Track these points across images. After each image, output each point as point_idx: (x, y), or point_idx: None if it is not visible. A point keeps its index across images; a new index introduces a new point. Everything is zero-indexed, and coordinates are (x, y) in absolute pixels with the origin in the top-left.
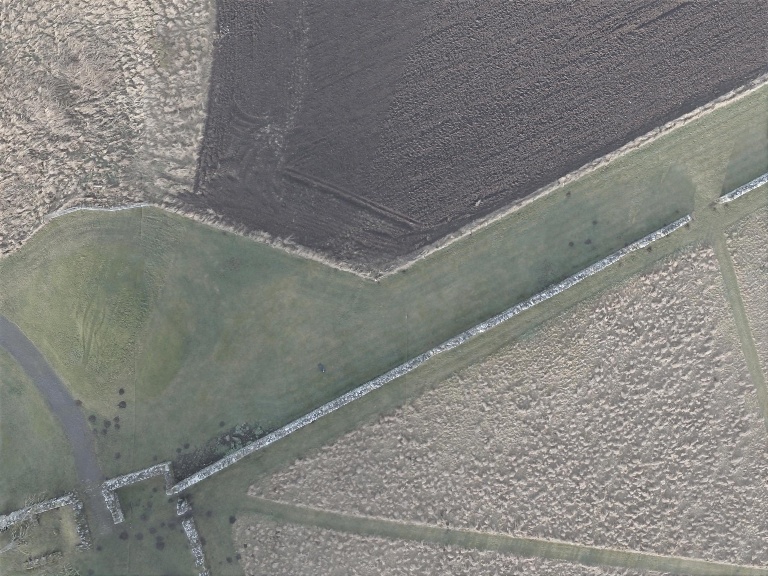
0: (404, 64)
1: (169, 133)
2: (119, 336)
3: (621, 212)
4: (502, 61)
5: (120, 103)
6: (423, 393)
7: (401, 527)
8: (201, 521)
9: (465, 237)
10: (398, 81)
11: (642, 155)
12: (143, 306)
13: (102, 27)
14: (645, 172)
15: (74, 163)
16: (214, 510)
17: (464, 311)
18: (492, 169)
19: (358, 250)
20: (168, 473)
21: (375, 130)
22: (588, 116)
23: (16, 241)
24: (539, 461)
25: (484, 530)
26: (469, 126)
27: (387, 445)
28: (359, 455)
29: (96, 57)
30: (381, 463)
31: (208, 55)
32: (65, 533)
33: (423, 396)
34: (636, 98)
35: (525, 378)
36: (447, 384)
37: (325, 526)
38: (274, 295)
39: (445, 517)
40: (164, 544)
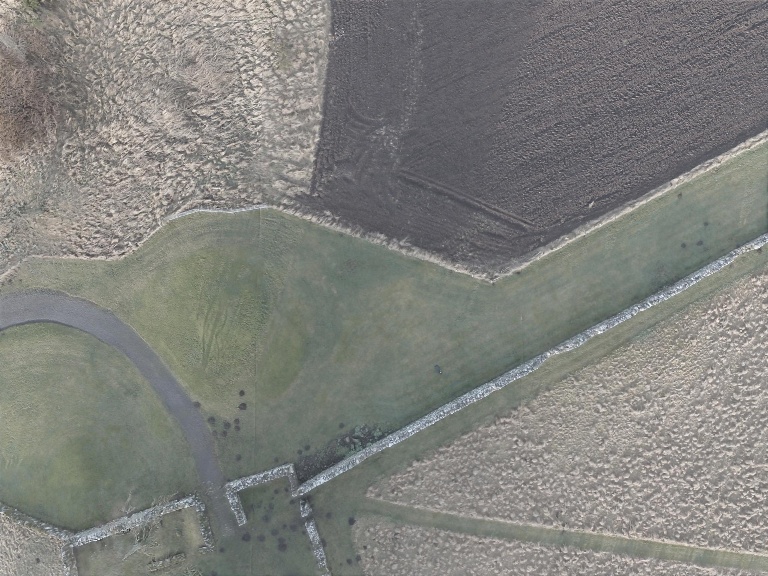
0: (517, 66)
1: (287, 135)
2: (241, 338)
3: (732, 213)
4: (614, 63)
5: (238, 105)
6: (538, 394)
7: (517, 528)
8: (321, 523)
9: (579, 238)
10: (511, 83)
11: (752, 156)
12: (264, 308)
13: (220, 29)
14: (755, 173)
15: (193, 165)
16: (333, 512)
17: (579, 312)
18: (605, 170)
19: (473, 252)
20: (292, 475)
21: (489, 132)
22: (700, 117)
23: (133, 243)
24: (653, 462)
25: (599, 531)
26: (582, 128)
27: (503, 446)
28: (475, 456)
29: (214, 59)
30: (497, 464)
31: (324, 57)
32: (188, 535)
33: (538, 397)
34: (747, 99)
35: (639, 379)
36: (562, 385)
37: (443, 527)
38: (391, 297)
39: (560, 518)
40: (286, 546)
